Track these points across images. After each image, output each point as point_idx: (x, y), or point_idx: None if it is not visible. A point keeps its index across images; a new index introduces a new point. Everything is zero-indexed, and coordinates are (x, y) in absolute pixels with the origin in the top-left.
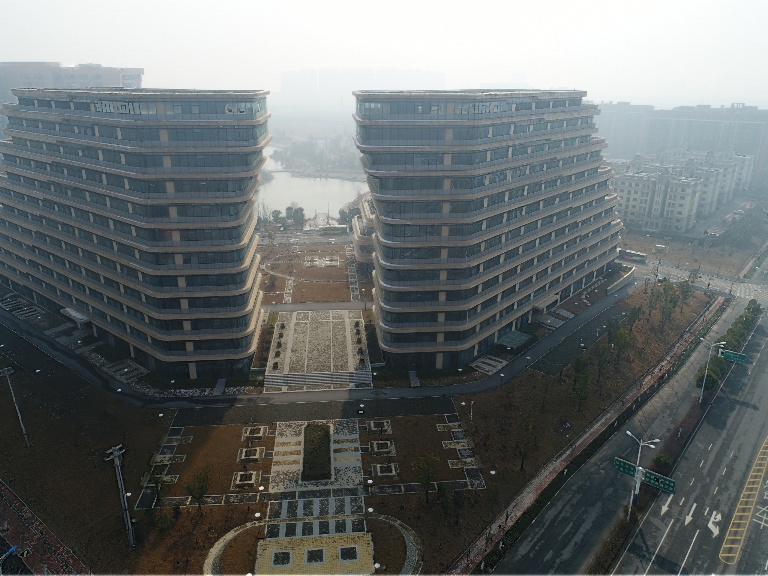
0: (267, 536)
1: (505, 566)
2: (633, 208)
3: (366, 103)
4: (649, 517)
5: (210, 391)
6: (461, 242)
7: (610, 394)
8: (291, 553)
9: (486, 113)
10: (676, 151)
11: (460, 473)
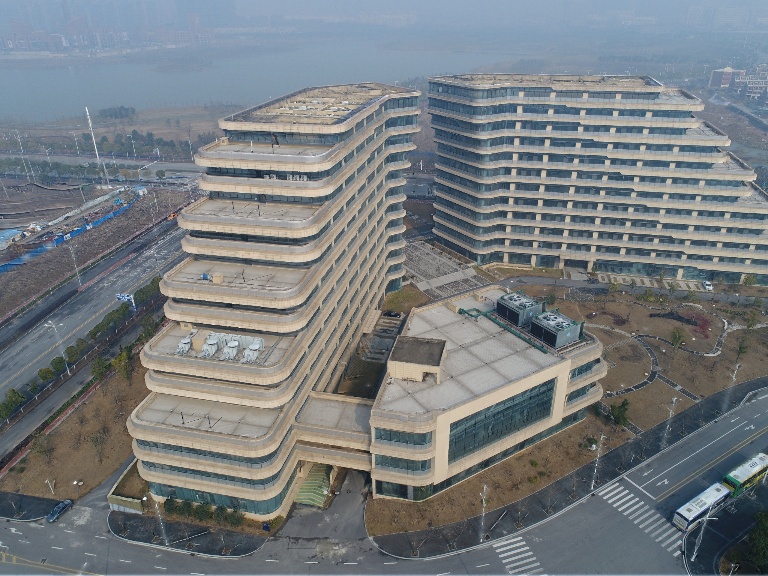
0: None
1: None
2: None
3: None
4: None
5: None
6: None
7: None
8: None
9: None
10: None
11: None
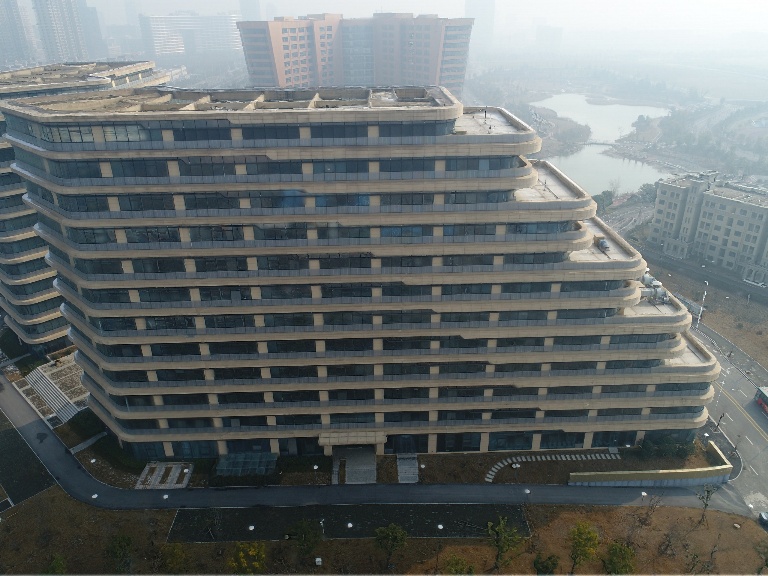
0: None
1: None
2: None
3: None
4: None
5: (3, 361)
6: (85, 309)
7: None
8: None
9: (83, 142)
10: None
11: None
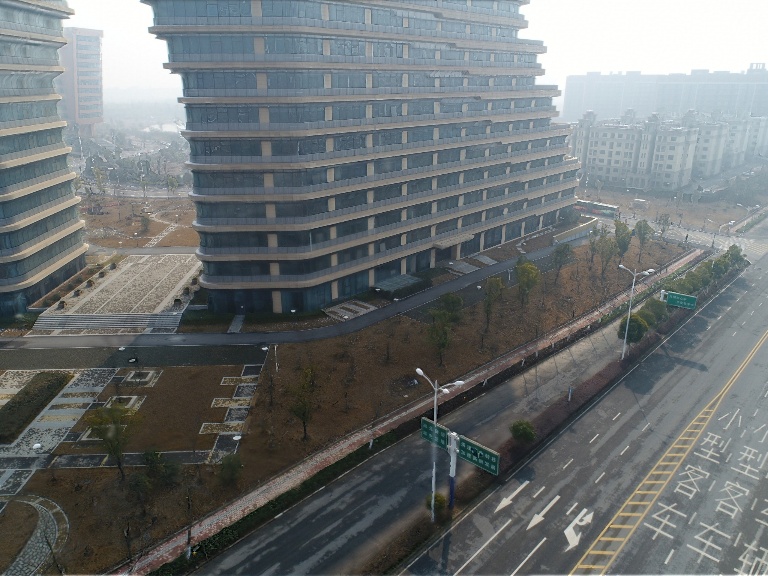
0: None
1: None
2: (616, 163)
3: None
4: (473, 514)
5: None
6: (286, 131)
7: (497, 346)
8: None
9: None
10: (680, 111)
11: (207, 440)
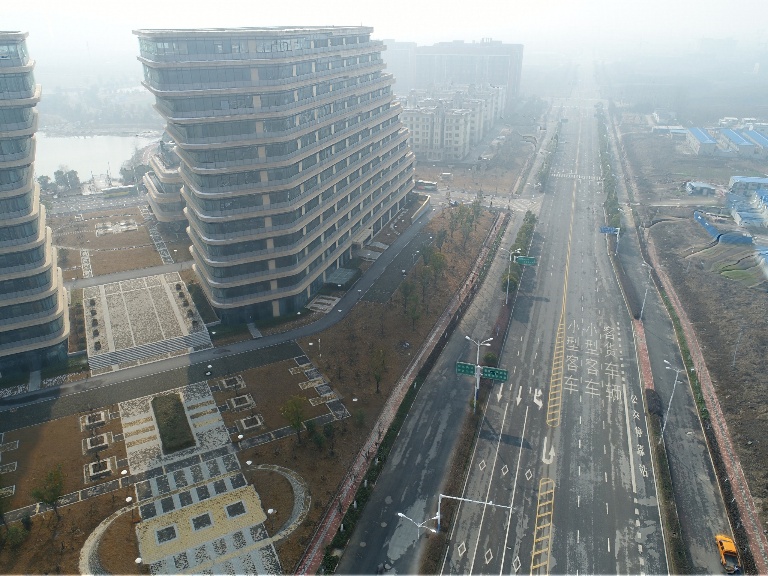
0: (143, 518)
1: (384, 478)
2: (417, 141)
3: (158, 43)
4: (489, 406)
5: (24, 388)
6: (282, 186)
7: (435, 310)
8: (175, 526)
9: (288, 51)
10: None
11: (323, 408)
